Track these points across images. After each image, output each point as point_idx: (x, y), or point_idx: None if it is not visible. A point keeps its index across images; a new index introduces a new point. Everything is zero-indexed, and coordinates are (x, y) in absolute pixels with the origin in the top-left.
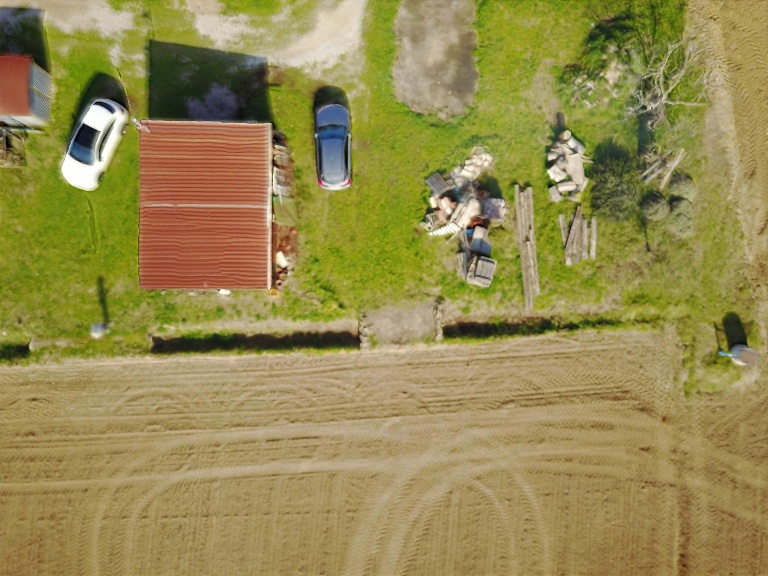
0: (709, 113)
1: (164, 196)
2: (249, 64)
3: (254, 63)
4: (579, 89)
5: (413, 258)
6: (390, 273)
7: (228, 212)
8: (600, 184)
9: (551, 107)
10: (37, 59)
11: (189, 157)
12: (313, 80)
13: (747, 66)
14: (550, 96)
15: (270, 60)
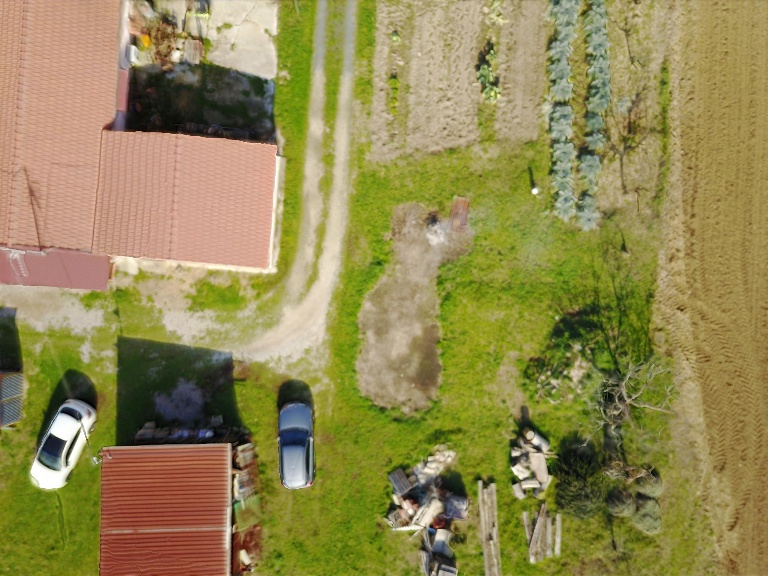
0: (676, 406)
1: (125, 522)
2: (214, 358)
3: (219, 357)
4: (542, 387)
5: (376, 553)
6: (353, 568)
7: (188, 536)
8: (564, 484)
9: (515, 400)
10: (9, 355)
11: (150, 481)
12: (277, 374)
13: (715, 359)
14: (514, 389)
15: (235, 354)
